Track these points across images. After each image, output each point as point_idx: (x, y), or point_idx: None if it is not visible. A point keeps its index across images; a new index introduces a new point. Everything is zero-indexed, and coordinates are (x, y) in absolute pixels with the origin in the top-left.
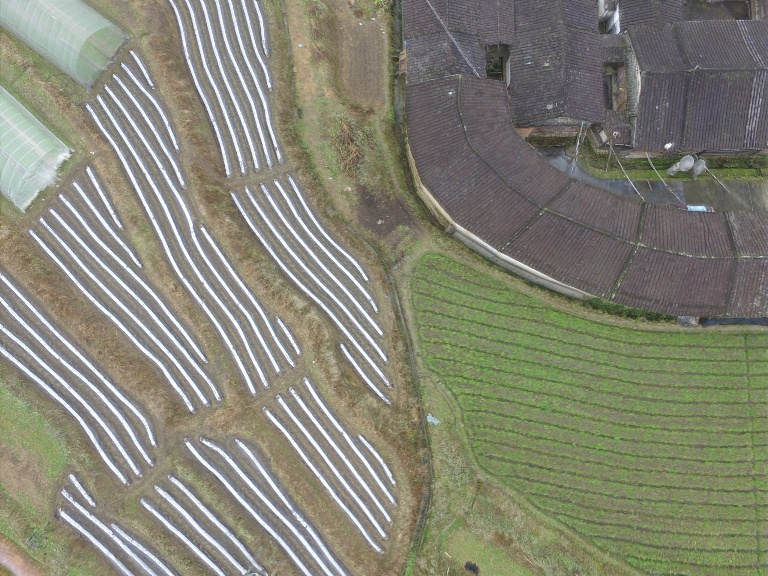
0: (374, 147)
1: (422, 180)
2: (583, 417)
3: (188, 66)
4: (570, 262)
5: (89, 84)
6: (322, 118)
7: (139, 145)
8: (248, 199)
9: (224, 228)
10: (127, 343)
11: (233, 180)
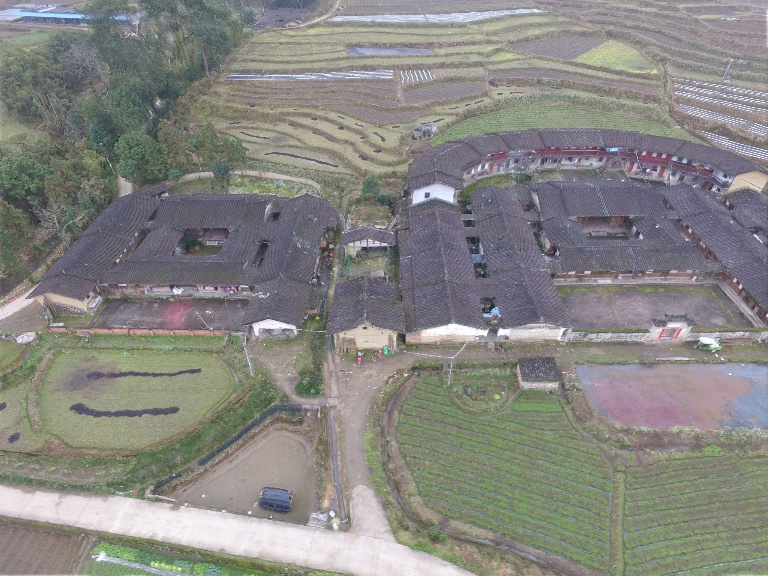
0: None
1: None
2: None
3: None
4: None
5: None
6: None
7: None
8: None
9: None
10: None
11: None
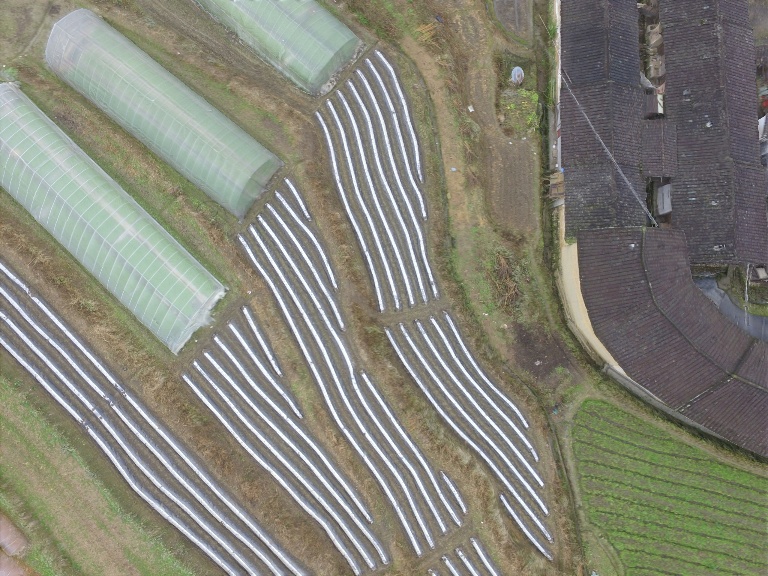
0: (531, 281)
1: (596, 332)
2: (747, 575)
3: (339, 190)
4: (754, 428)
5: (243, 215)
6: (477, 249)
7: (294, 281)
8: (403, 337)
9: (386, 375)
10: (287, 500)
11: (387, 315)
